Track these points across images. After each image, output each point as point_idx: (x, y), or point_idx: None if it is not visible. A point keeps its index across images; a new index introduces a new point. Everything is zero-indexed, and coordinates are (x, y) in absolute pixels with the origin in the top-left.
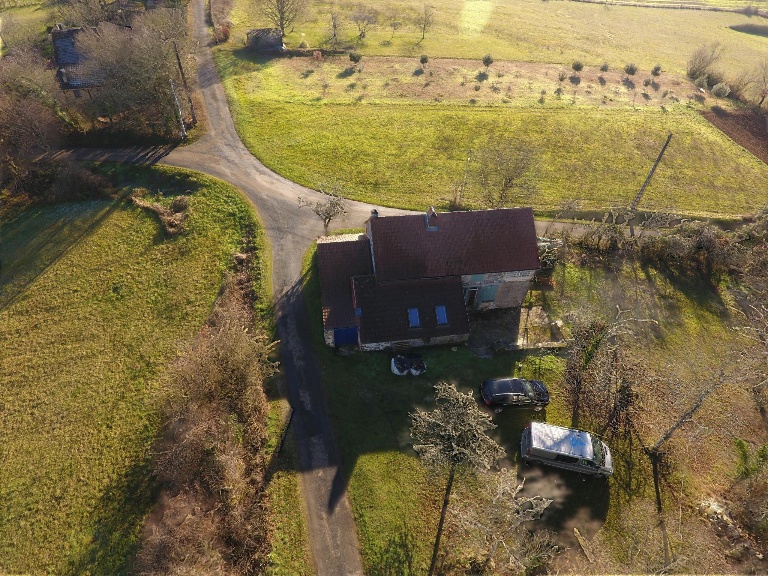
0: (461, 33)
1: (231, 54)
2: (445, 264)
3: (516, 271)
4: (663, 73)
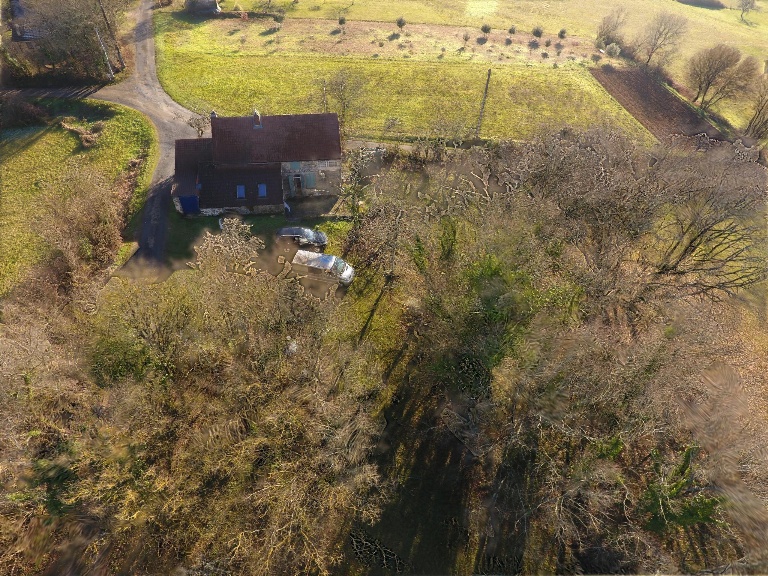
0: (392, 1)
1: (170, 15)
2: (267, 153)
3: (325, 161)
4: (573, 37)
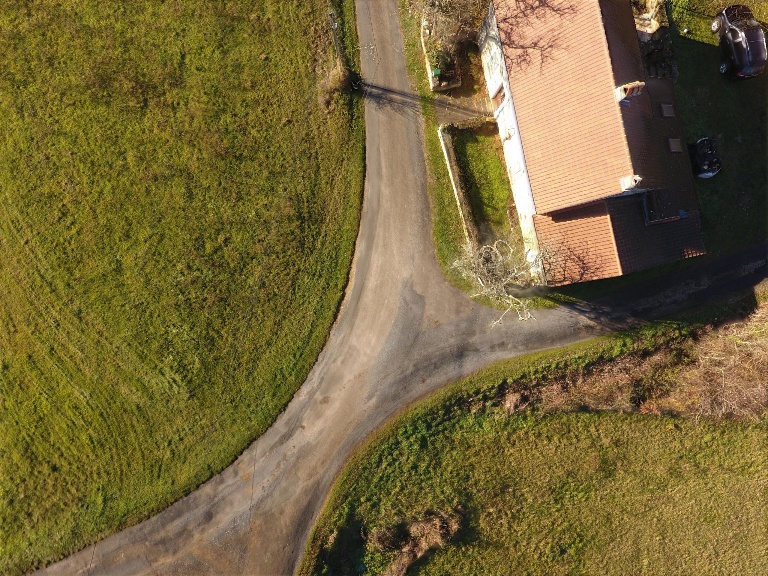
0: None
1: None
2: (643, 90)
3: None
4: None
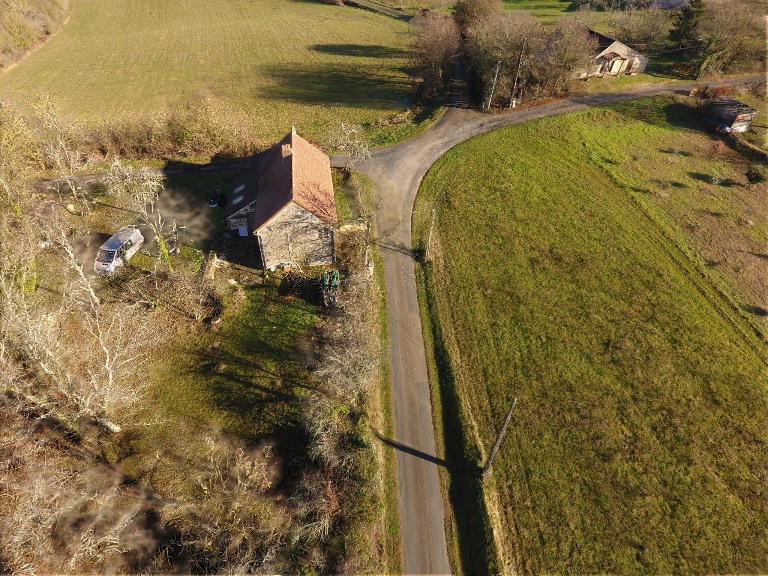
0: None
1: (669, 104)
2: None
3: None
4: None
